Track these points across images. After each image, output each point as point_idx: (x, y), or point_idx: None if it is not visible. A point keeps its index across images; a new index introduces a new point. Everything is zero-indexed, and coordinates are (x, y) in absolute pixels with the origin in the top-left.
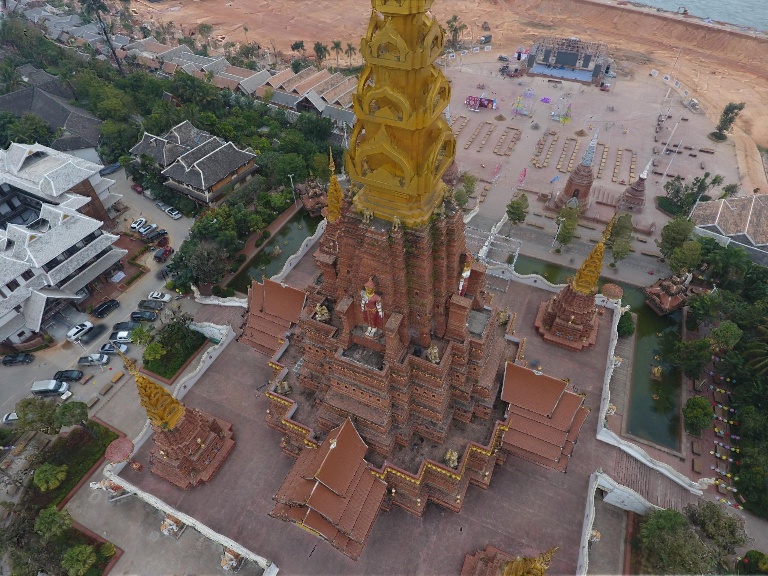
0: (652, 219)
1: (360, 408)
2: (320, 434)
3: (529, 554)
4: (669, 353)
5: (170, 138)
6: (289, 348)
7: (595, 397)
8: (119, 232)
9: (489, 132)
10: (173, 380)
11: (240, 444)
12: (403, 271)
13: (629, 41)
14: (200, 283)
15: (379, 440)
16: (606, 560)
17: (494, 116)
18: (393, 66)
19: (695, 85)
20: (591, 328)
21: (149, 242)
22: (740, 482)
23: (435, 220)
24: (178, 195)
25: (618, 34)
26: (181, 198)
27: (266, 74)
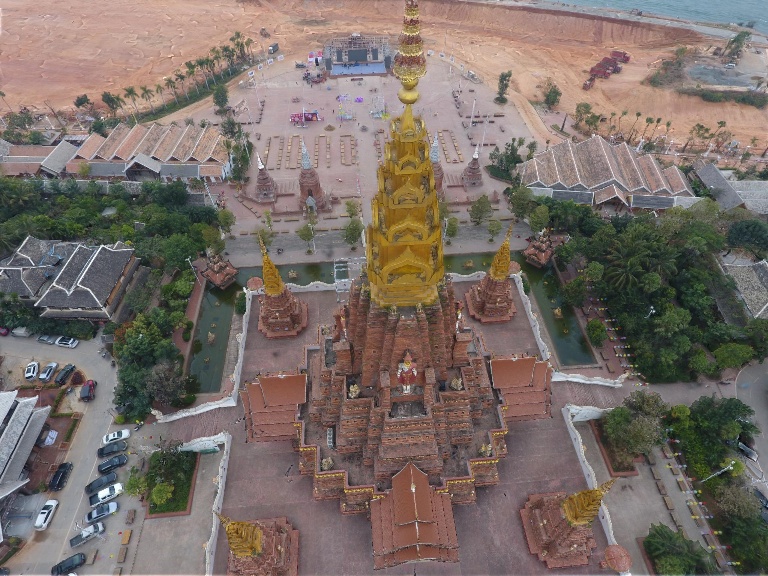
0: (492, 188)
1: (412, 449)
2: (380, 485)
3: (554, 486)
4: (552, 292)
5: (17, 262)
6: (307, 427)
7: (536, 351)
8: (14, 389)
9: (328, 145)
10: (189, 509)
11: (302, 529)
12: None
13: (396, 24)
14: (164, 405)
15: (434, 465)
16: (593, 461)
17: (323, 128)
18: (412, 207)
19: (464, 57)
20: (511, 301)
21: (60, 385)
22: (639, 367)
23: (440, 291)
24: (63, 321)
25: (384, 19)
26: (70, 323)
27: (66, 145)
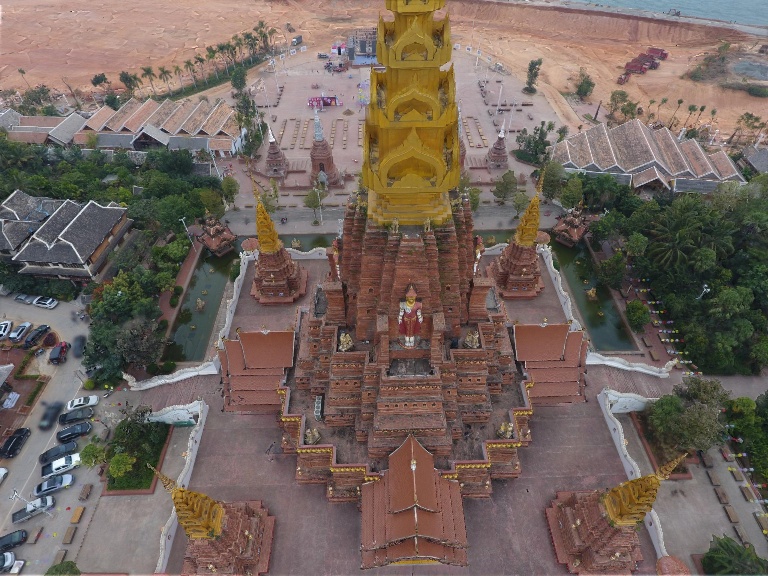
0: (518, 171)
1: (414, 420)
2: (374, 465)
3: (589, 483)
4: None
5: (2, 216)
6: (293, 395)
7: None
8: None
9: (345, 128)
10: (153, 487)
11: (280, 516)
12: (437, 270)
13: None
14: (136, 368)
15: (441, 443)
16: (635, 459)
17: (342, 112)
18: (420, 66)
19: (492, 51)
20: (539, 274)
21: (31, 346)
22: (689, 354)
23: (455, 212)
24: (43, 280)
25: None
26: (50, 282)
27: (77, 118)
